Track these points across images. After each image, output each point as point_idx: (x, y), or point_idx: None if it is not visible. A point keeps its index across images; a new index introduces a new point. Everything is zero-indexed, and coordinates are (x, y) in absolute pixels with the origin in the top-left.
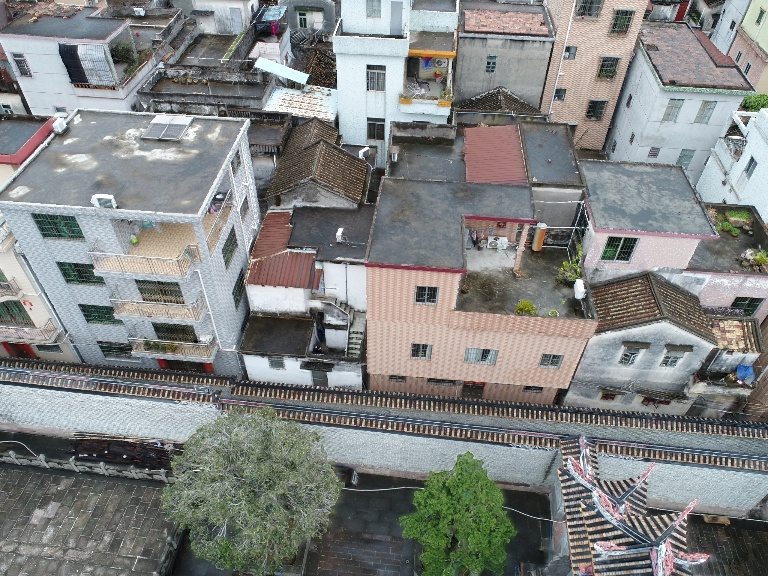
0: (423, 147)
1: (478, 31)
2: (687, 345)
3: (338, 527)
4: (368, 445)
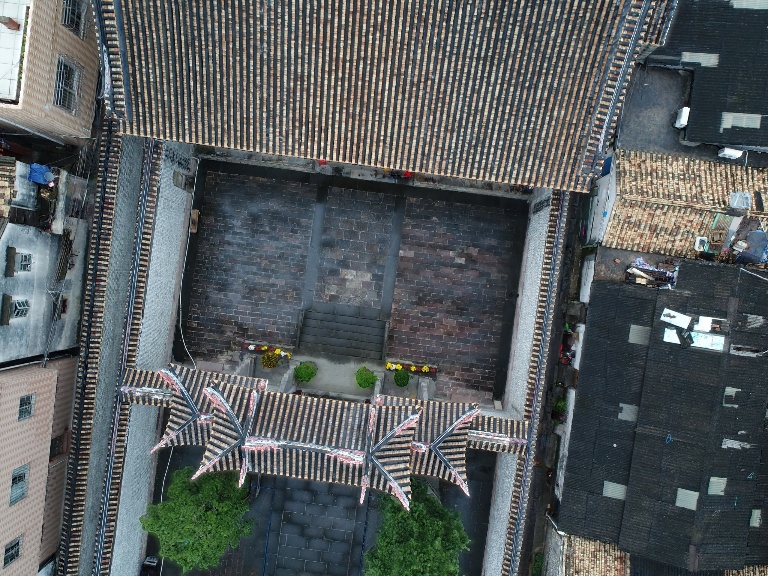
0: None
1: None
2: (6, 253)
3: (198, 574)
4: (121, 573)
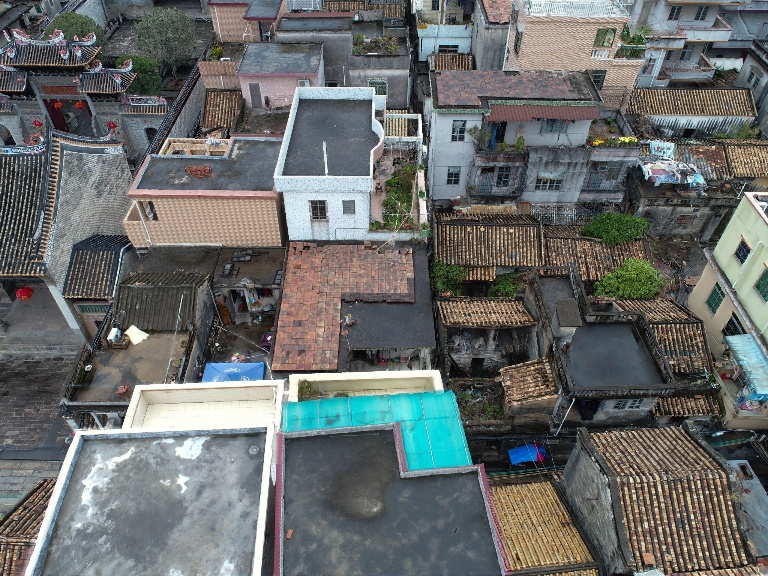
0: (372, 29)
1: (482, 0)
2: None
3: None
4: None
